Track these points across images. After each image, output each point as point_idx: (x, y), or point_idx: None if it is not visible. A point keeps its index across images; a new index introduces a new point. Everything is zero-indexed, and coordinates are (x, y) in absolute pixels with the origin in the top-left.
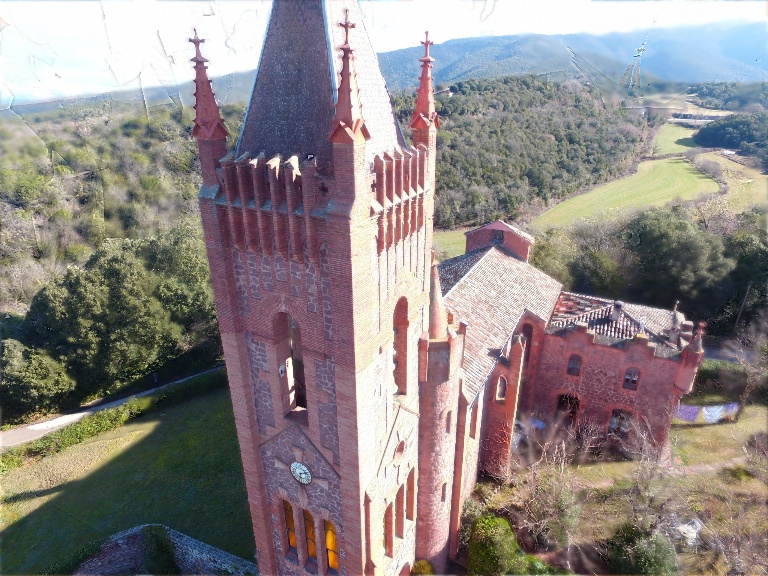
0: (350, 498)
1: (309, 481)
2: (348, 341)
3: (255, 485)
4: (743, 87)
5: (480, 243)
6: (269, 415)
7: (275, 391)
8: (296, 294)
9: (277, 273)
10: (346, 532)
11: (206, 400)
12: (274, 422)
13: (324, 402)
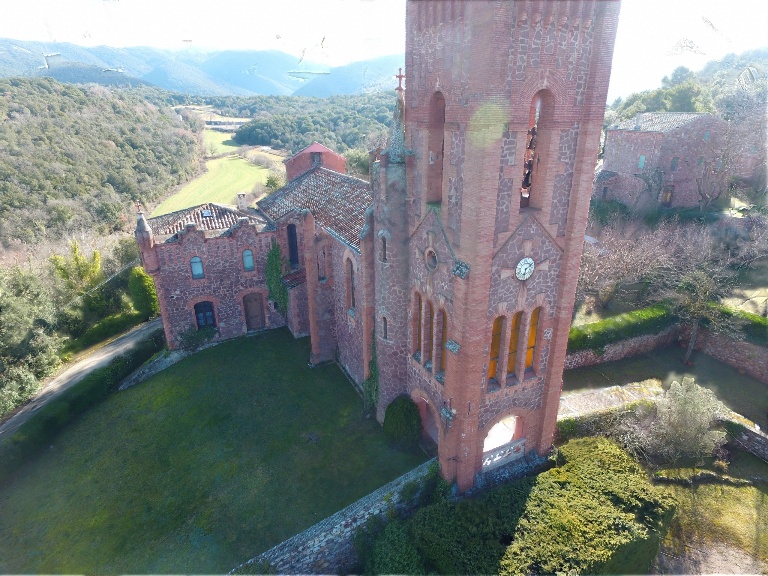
0: (575, 257)
1: (531, 273)
2: (603, 95)
3: (483, 313)
4: (348, 63)
5: (301, 169)
6: (503, 220)
7: (517, 185)
8: (558, 66)
9: (546, 46)
10: (564, 297)
11: (20, 488)
12: (508, 225)
13: (561, 174)
